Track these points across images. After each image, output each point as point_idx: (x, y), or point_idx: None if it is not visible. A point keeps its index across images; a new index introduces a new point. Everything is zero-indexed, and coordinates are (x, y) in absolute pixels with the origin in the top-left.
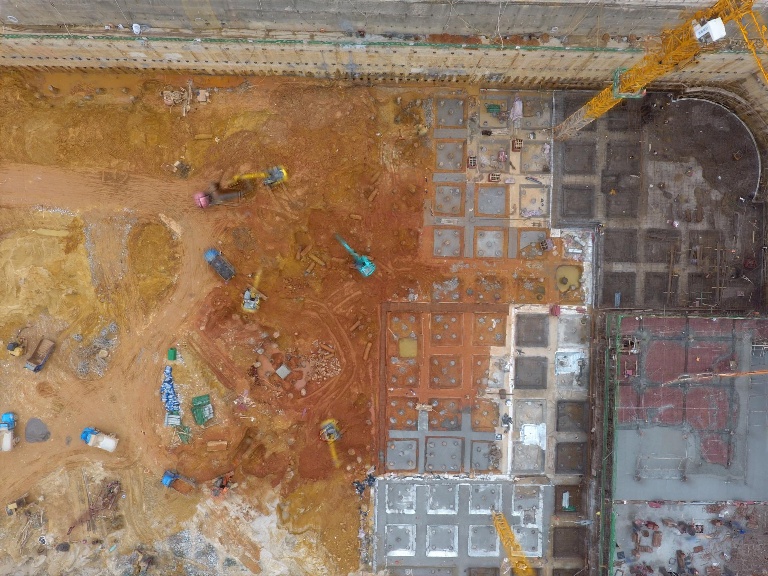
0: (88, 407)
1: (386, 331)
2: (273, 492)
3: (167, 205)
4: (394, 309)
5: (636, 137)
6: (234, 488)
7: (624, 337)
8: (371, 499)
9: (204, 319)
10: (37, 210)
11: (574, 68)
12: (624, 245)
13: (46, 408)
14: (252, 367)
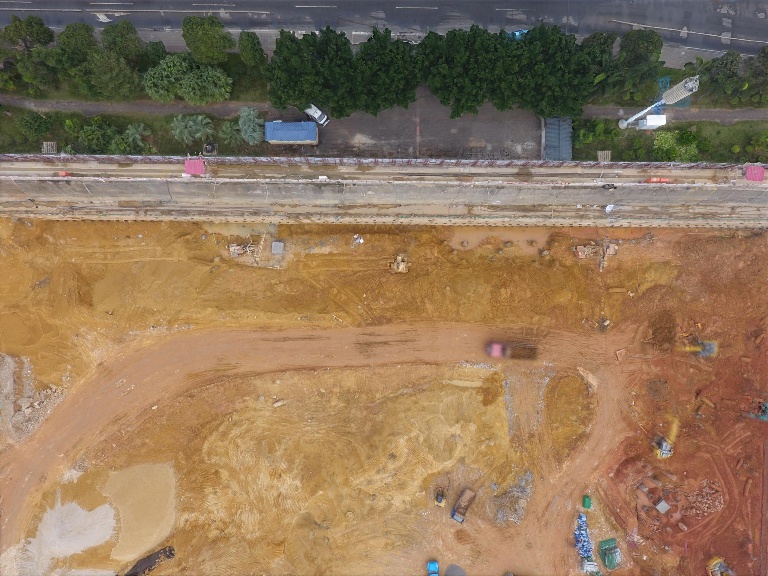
0: (505, 553)
1: None
2: None
3: (585, 358)
4: None
5: None
6: None
7: None
8: None
9: (615, 467)
10: (461, 365)
11: None
12: None
13: (464, 555)
14: (636, 504)
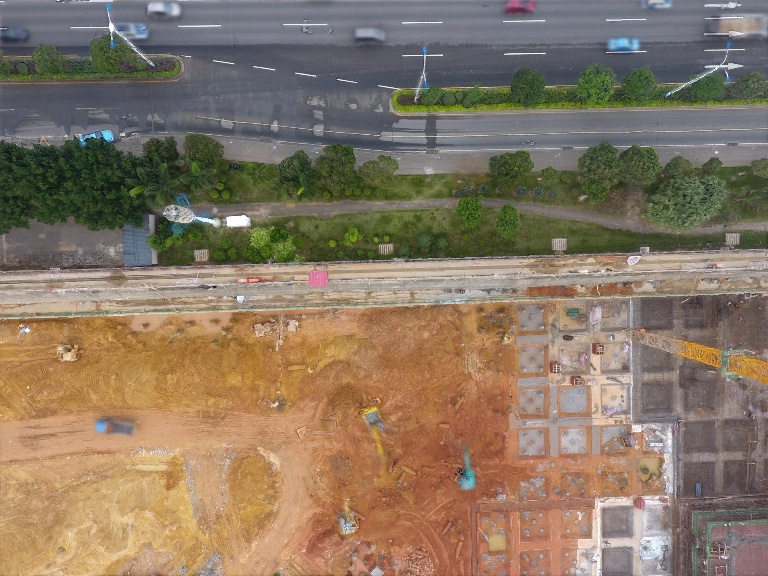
0: None
1: (477, 531)
2: None
3: (265, 438)
4: (484, 510)
5: (711, 333)
6: None
7: (714, 543)
8: None
9: (305, 543)
10: (137, 452)
11: None
12: None
13: None
14: (348, 572)
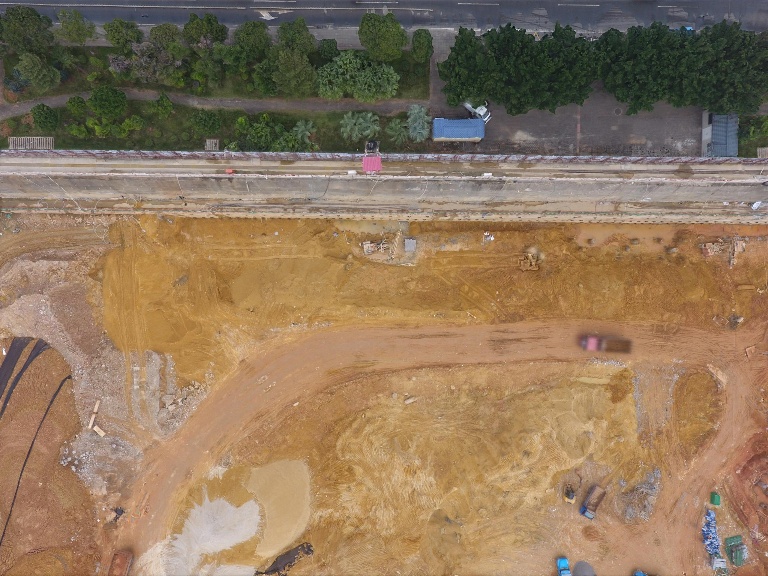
0: (633, 550)
1: None
2: None
3: (714, 355)
4: None
5: None
6: None
7: None
8: None
9: (743, 464)
10: (592, 362)
11: None
12: None
13: (593, 551)
14: None
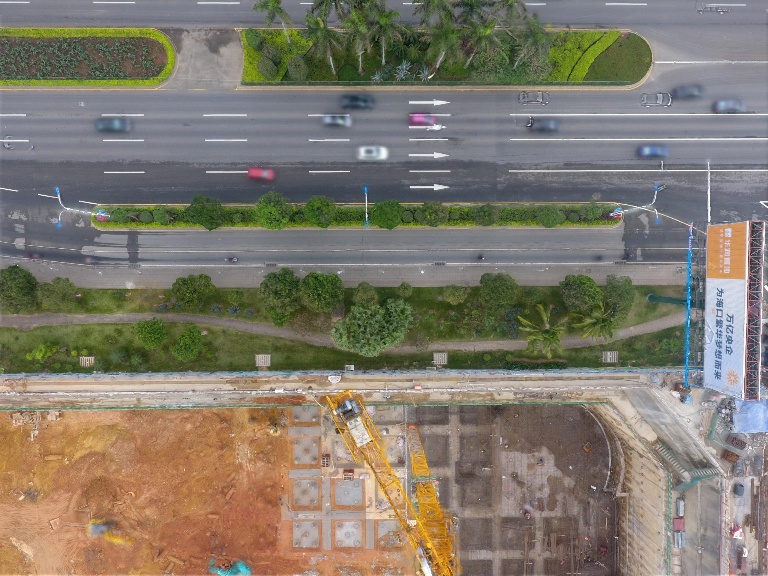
0: None
1: None
2: None
3: (18, 529)
4: None
5: (488, 429)
6: None
7: None
8: None
9: None
10: None
11: None
12: (481, 531)
13: None
14: None
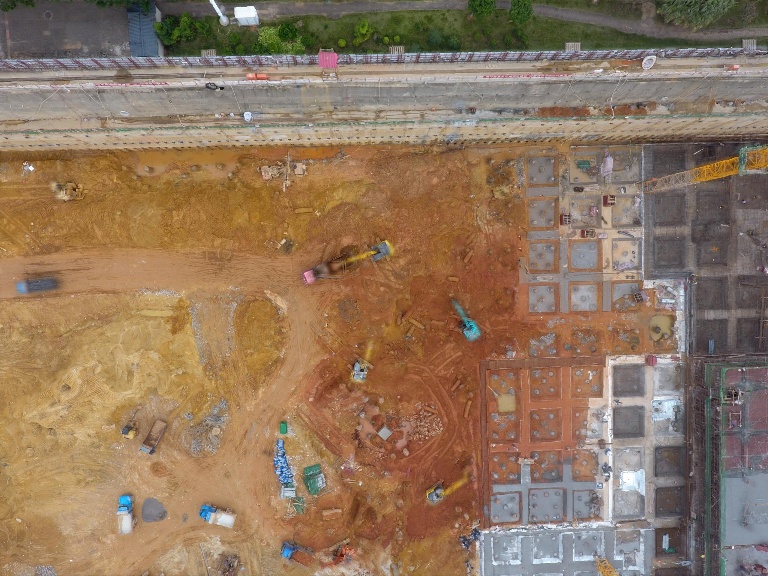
0: (203, 484)
1: (486, 389)
2: (385, 553)
3: (272, 281)
4: (493, 367)
5: (724, 186)
6: (350, 554)
7: (728, 389)
8: (477, 552)
9: (313, 391)
10: (143, 293)
11: (673, 128)
12: (714, 292)
13: (161, 487)
14: (355, 431)
